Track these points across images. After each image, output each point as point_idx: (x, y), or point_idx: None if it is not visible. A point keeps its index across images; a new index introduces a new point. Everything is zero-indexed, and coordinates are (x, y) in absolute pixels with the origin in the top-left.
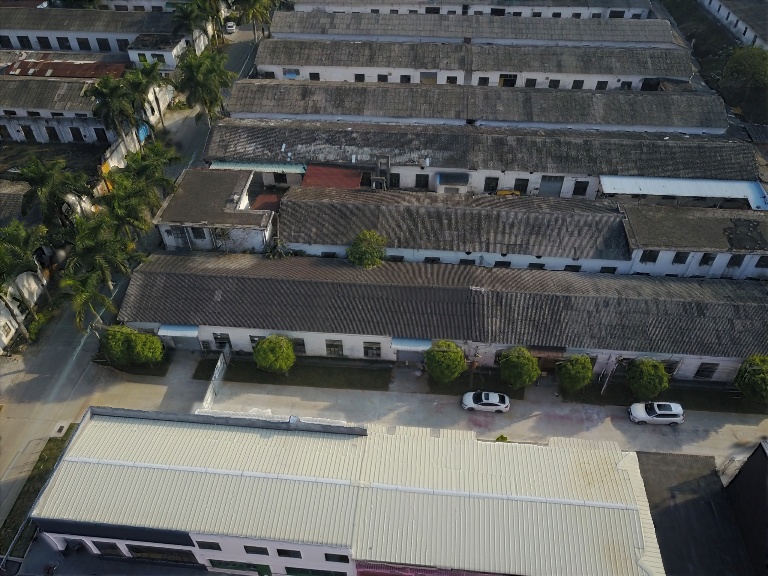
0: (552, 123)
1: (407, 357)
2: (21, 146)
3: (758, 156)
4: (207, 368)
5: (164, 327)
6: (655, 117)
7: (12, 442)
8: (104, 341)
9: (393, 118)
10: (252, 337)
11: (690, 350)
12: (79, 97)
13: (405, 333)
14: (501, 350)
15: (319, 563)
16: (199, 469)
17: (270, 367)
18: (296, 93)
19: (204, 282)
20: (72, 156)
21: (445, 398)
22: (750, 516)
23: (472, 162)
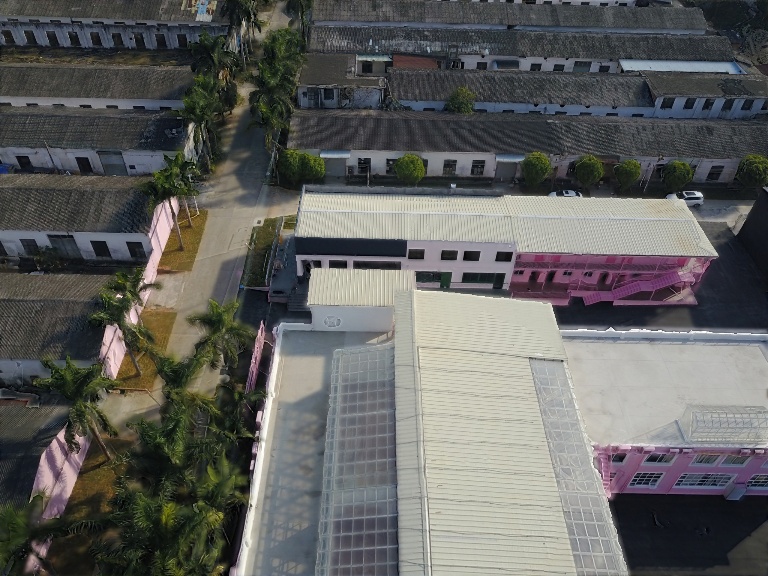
0: (575, 27)
1: (502, 174)
2: (133, 52)
3: None
4: None
5: (324, 152)
6: (653, 22)
7: (226, 230)
8: (282, 161)
9: (449, 25)
10: (388, 161)
11: (705, 155)
12: (181, 11)
13: (505, 150)
14: (573, 162)
15: (489, 265)
16: (398, 212)
17: (410, 175)
18: (367, 6)
19: (348, 122)
20: (182, 58)
21: None
22: (757, 241)
23: (522, 51)
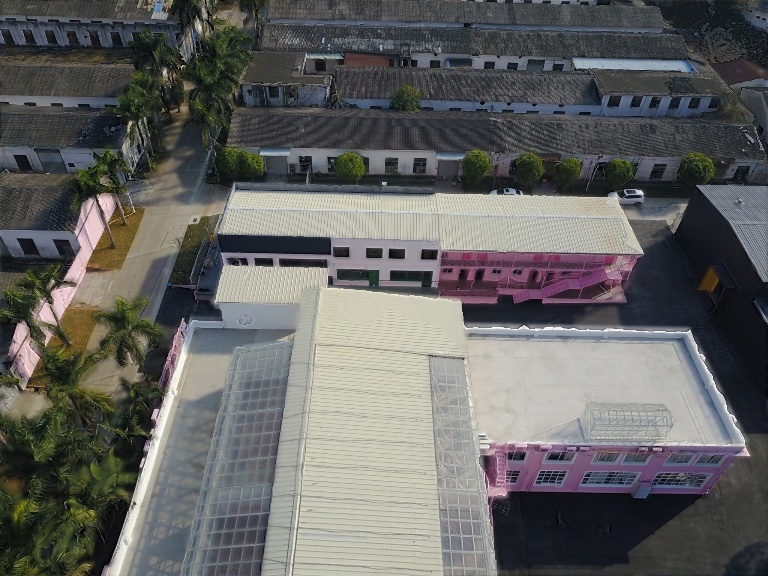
0: (531, 26)
1: (445, 172)
2: (88, 50)
3: (687, 47)
4: None
5: (264, 150)
6: (609, 21)
7: (161, 228)
8: (220, 158)
9: (405, 23)
10: (329, 159)
11: (647, 153)
12: (137, 9)
13: (446, 148)
14: (515, 160)
15: (415, 263)
16: (326, 210)
17: (349, 173)
18: (324, 4)
19: (289, 120)
20: (136, 56)
21: None
22: (691, 239)
23: (474, 49)
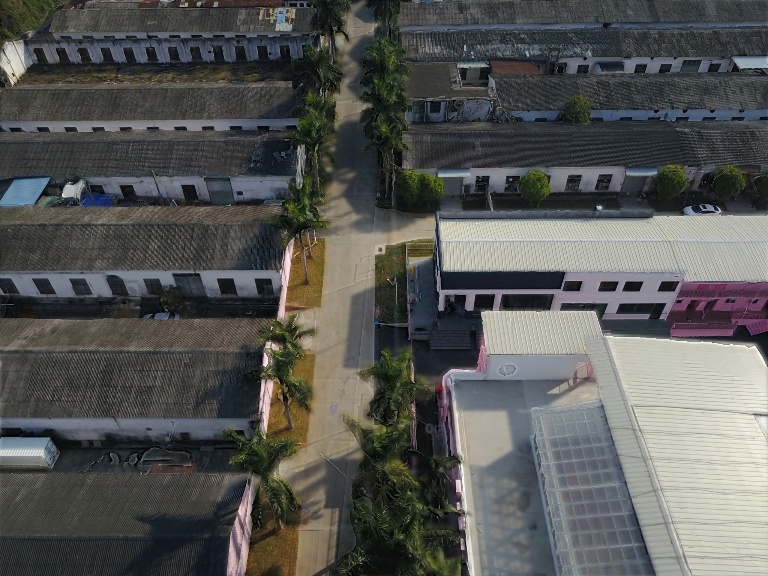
0: (676, 23)
1: (628, 188)
2: (212, 66)
3: None
4: (471, 206)
5: (441, 171)
6: (759, 14)
7: (348, 259)
8: (400, 182)
9: (541, 25)
10: (508, 178)
11: None
12: (259, 21)
13: (636, 163)
14: (709, 173)
15: (649, 295)
16: (547, 240)
17: (536, 194)
18: (453, 8)
19: (463, 137)
20: (263, 71)
21: (668, 213)
22: None
23: (626, 51)
